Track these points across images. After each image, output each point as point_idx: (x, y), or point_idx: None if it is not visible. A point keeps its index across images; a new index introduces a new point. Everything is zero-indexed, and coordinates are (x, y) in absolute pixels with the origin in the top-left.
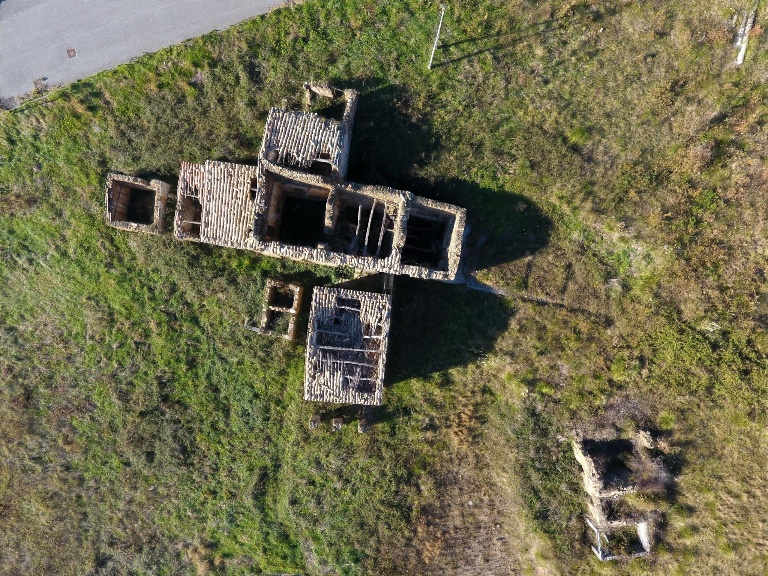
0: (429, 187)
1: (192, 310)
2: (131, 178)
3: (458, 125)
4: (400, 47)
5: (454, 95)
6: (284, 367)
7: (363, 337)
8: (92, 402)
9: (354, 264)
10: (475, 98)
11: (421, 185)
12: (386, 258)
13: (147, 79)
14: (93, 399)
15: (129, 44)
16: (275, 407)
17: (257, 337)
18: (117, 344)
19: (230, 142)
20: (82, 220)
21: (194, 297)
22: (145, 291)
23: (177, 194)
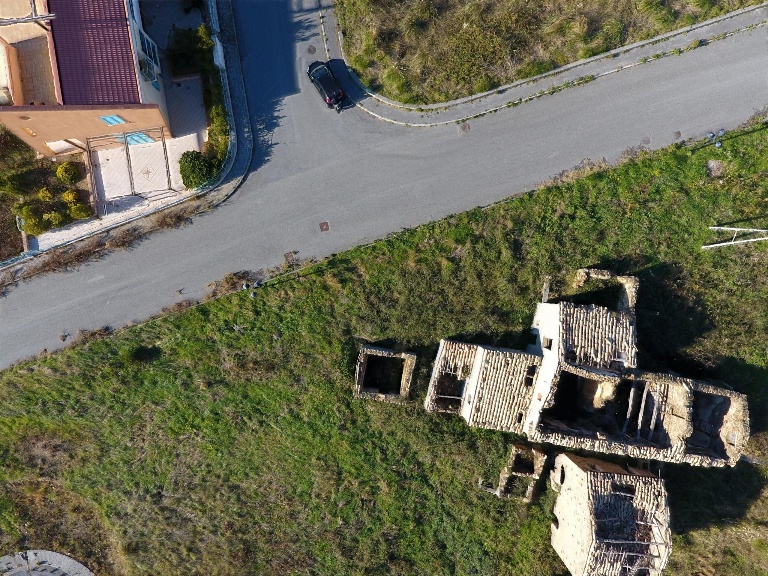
0: (693, 363)
1: (422, 469)
2: (385, 353)
3: (729, 304)
4: (671, 225)
5: (727, 274)
6: (517, 526)
7: (636, 522)
8: (313, 557)
9: (636, 454)
10: (749, 278)
11: (685, 360)
12: (669, 449)
13: (406, 255)
14: (314, 554)
15: (386, 219)
16: (506, 566)
17: (491, 497)
18: (343, 502)
19: (489, 318)
20: (321, 386)
21: (427, 457)
22: (377, 452)
23: (435, 371)
